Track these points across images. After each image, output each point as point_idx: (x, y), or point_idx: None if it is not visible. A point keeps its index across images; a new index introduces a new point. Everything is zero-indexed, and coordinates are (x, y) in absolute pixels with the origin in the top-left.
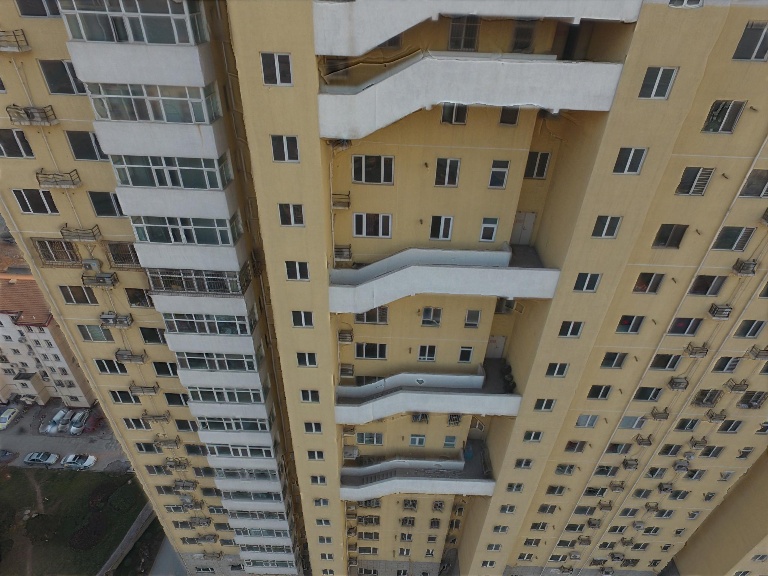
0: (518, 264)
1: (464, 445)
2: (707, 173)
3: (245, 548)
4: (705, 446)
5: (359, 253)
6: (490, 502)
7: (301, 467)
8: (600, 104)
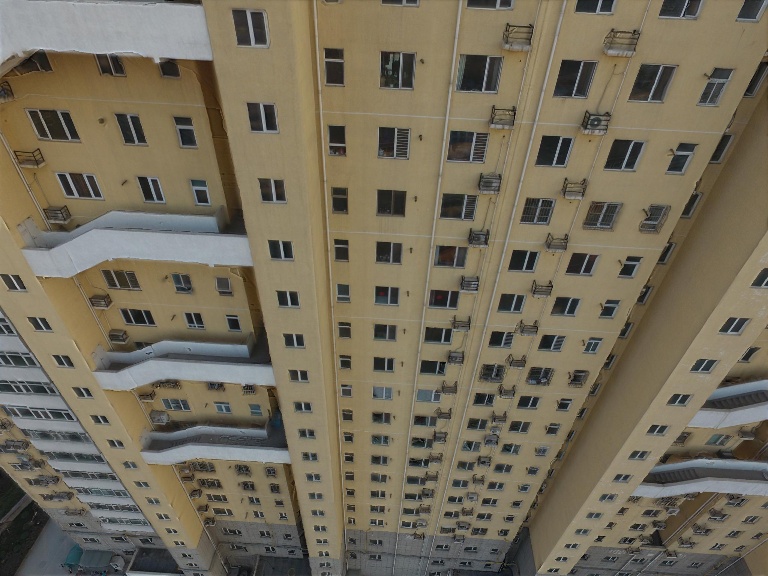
0: (232, 230)
1: (270, 413)
2: (404, 134)
3: (94, 506)
4: (510, 421)
5: (79, 215)
6: (292, 470)
7: (91, 431)
8: (201, 52)
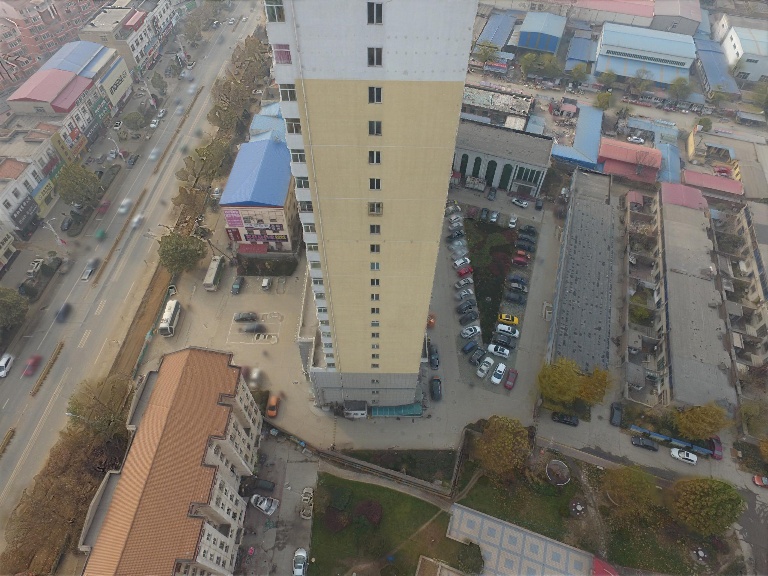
0: None
1: None
2: None
3: None
4: None
5: None
6: None
7: None
8: None
